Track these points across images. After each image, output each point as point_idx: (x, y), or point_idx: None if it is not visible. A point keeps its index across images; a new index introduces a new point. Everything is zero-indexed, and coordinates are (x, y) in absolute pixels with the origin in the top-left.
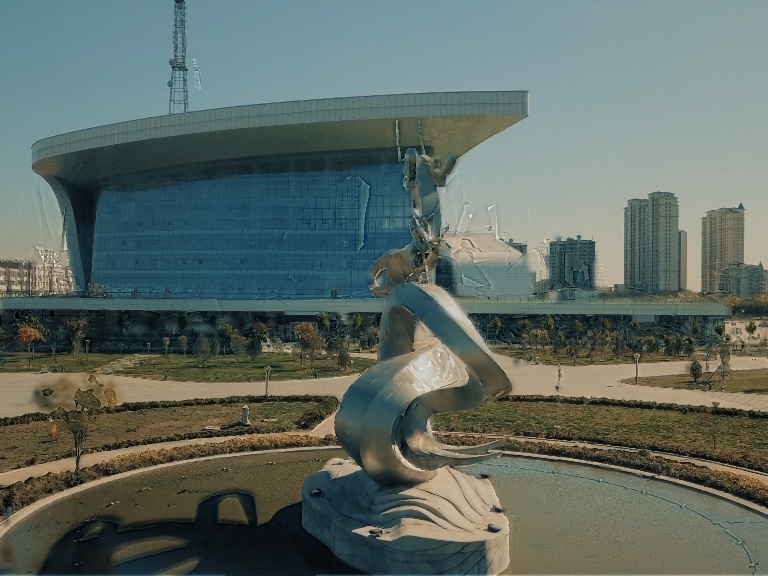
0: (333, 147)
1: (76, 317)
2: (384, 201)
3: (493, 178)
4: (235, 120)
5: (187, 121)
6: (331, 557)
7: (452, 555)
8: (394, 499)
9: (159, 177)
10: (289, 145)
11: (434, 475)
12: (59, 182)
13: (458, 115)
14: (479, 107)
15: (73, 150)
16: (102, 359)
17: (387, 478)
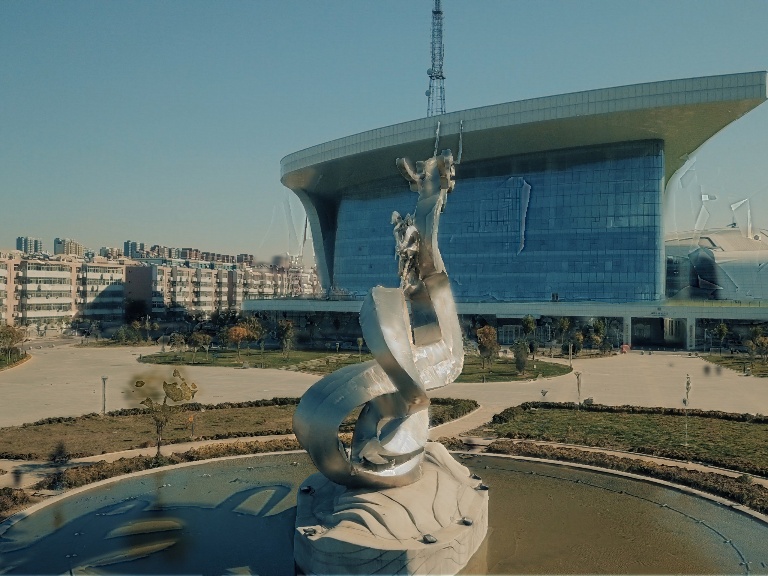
0: (555, 146)
1: (305, 318)
2: (608, 200)
3: (745, 169)
4: (452, 125)
5: (408, 130)
6: None
7: (369, 561)
8: (349, 501)
9: (391, 185)
10: (509, 147)
11: (412, 482)
12: (306, 193)
13: (684, 104)
14: (708, 93)
15: (312, 163)
16: (305, 357)
17: (348, 480)
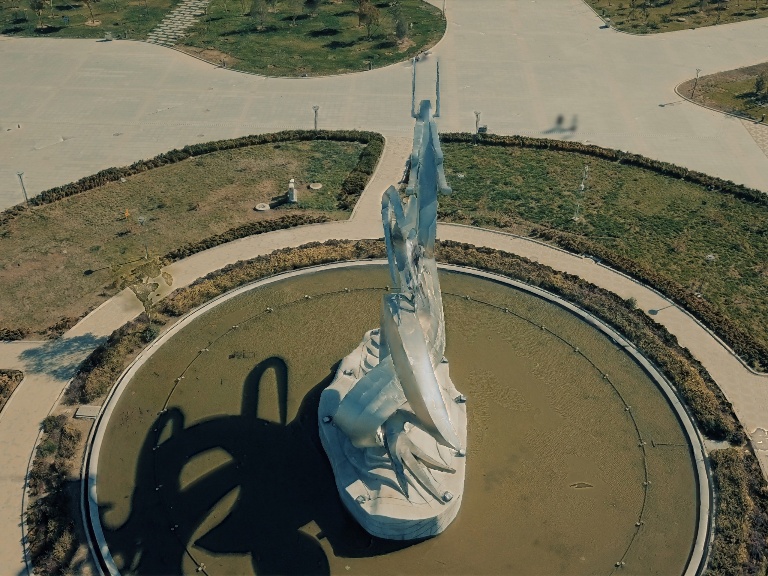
0: None
1: None
2: None
3: None
4: None
5: None
6: None
7: (412, 526)
8: (379, 460)
9: None
10: None
11: None
12: None
13: None
14: None
15: None
16: (162, 3)
17: None
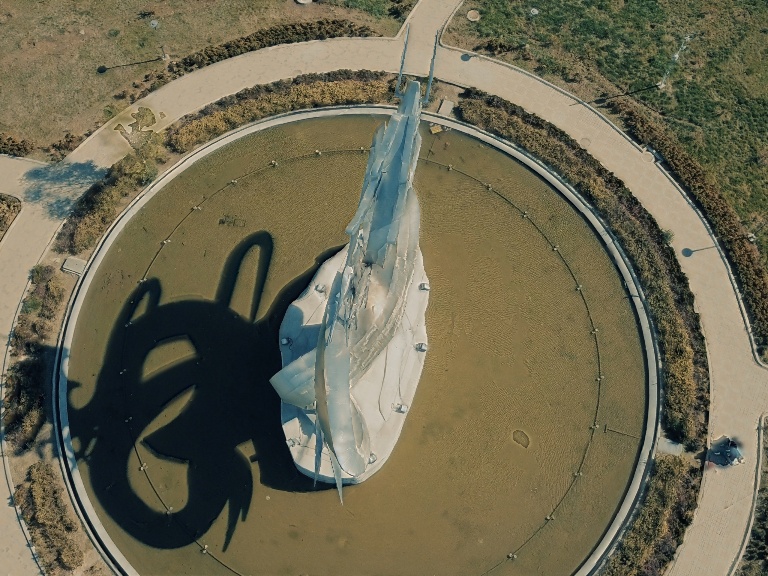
0: None
1: None
2: None
3: None
4: None
5: None
6: None
7: (331, 479)
8: None
9: None
10: None
11: (365, 372)
12: None
13: None
14: None
15: None
16: None
17: None
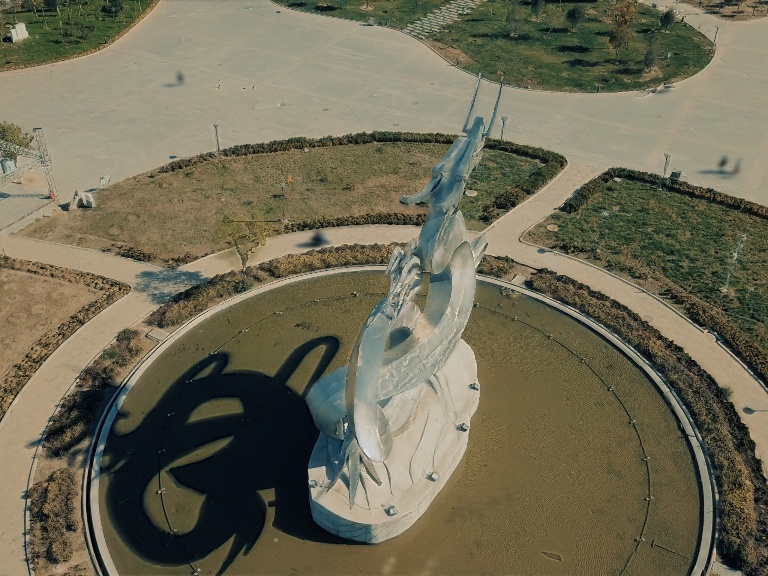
0: None
1: None
2: None
3: None
4: None
5: None
6: None
7: (346, 525)
8: None
9: None
10: None
11: (402, 432)
12: None
13: None
14: None
15: None
16: None
17: None
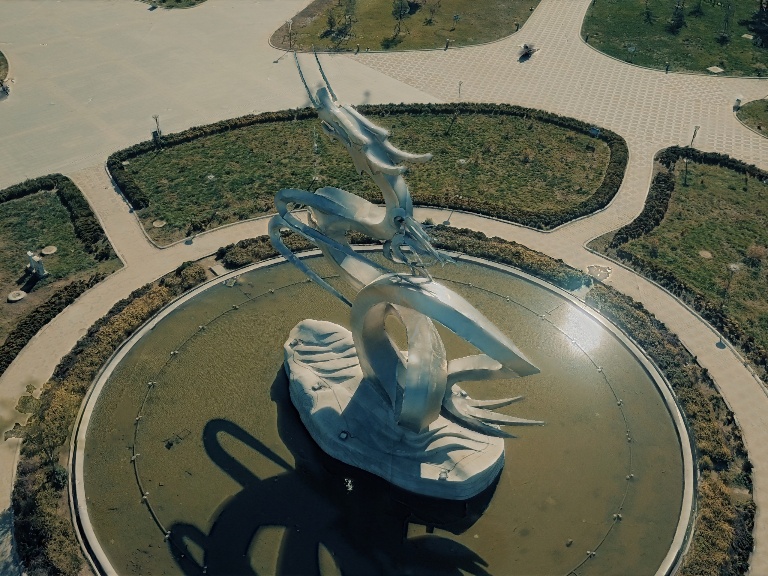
0: None
1: None
2: None
3: None
4: None
5: None
6: (389, 485)
7: None
8: (428, 436)
9: None
10: None
11: None
12: None
13: None
14: None
15: None
16: None
17: None
